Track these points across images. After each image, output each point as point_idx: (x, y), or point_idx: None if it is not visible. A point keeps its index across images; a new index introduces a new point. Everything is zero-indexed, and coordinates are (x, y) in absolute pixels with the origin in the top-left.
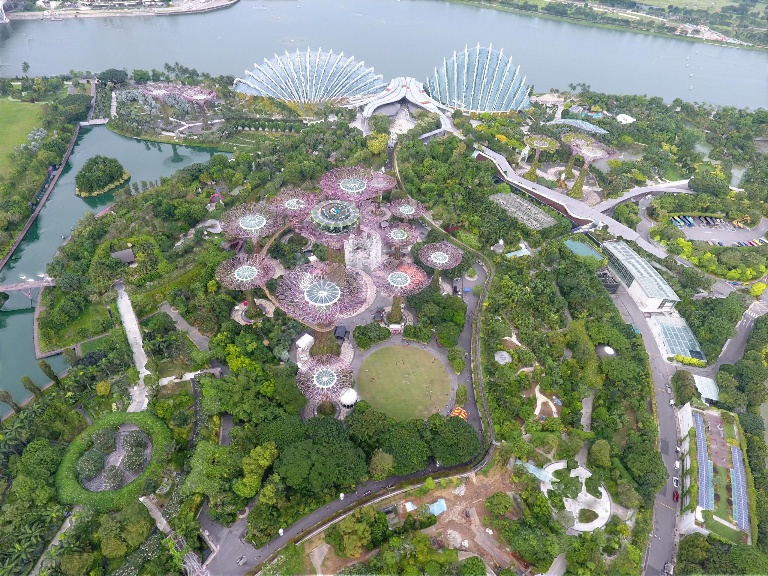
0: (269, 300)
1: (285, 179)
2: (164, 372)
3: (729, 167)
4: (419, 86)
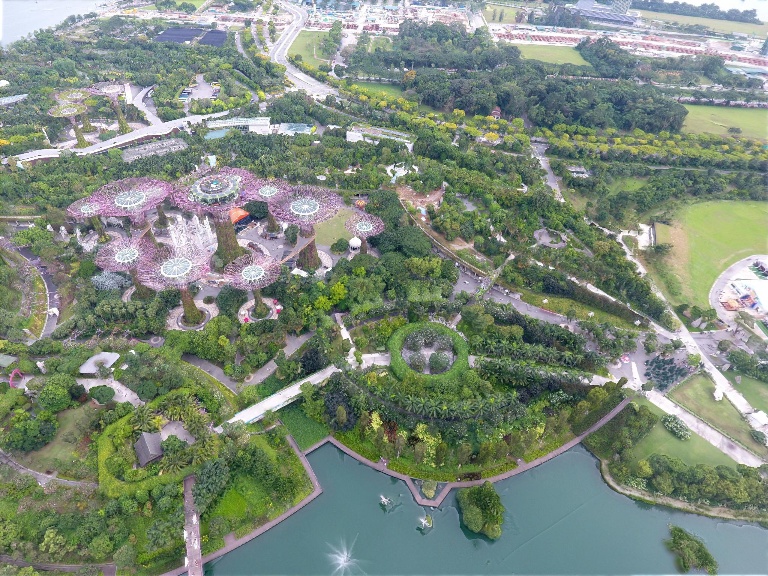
0: (242, 305)
1: (4, 304)
2: (342, 351)
3: (122, 67)
4: None
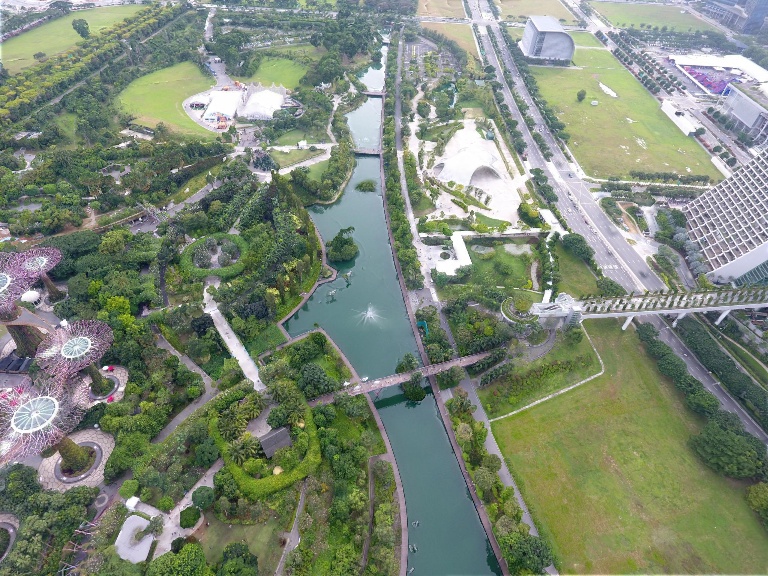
0: None
1: None
2: None
3: None
4: None
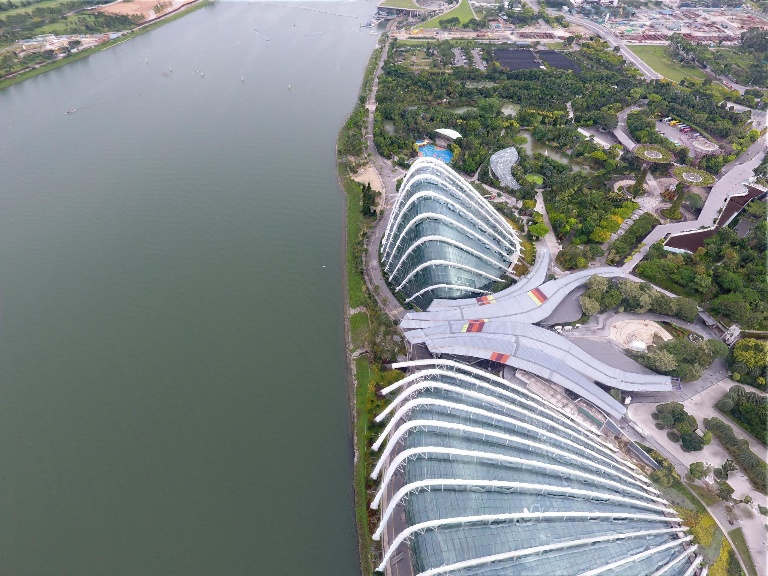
0: None
1: None
2: None
3: (548, 105)
4: (454, 306)
